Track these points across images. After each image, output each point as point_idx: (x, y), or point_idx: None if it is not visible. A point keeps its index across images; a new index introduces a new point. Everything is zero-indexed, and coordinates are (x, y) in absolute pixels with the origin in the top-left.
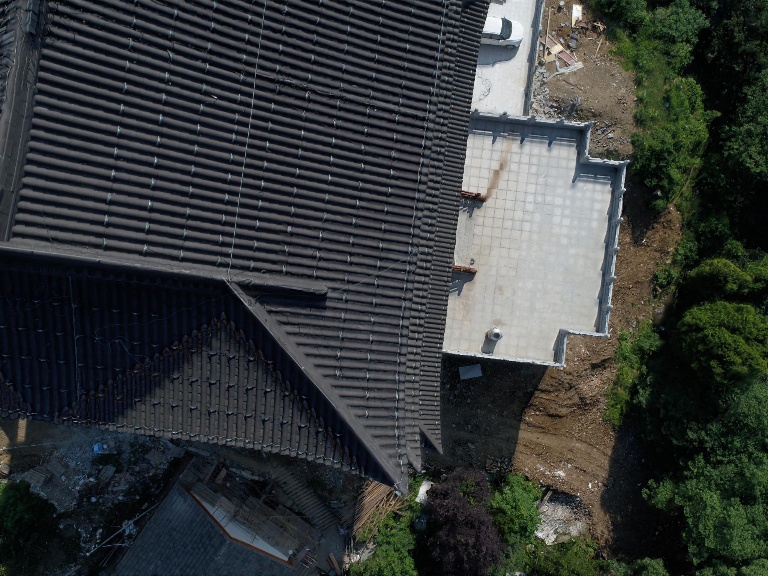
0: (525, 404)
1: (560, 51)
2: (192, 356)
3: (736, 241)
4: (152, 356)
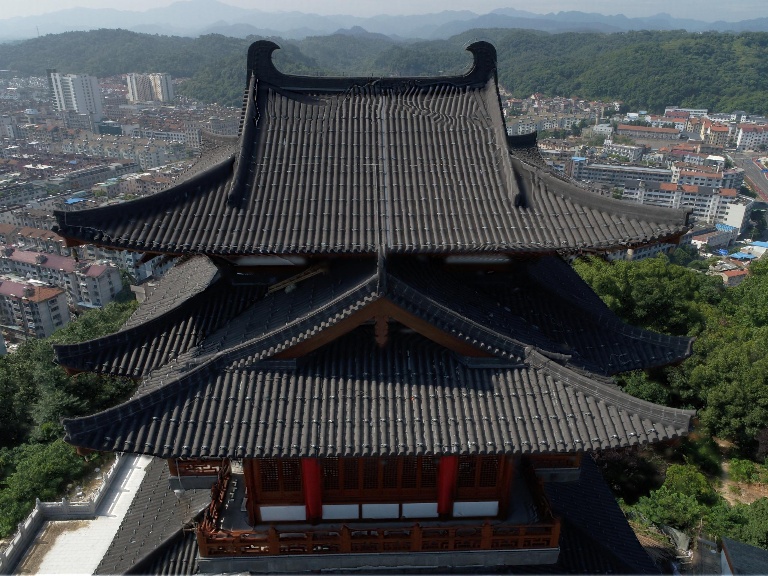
0: None
1: None
2: None
3: None
4: None
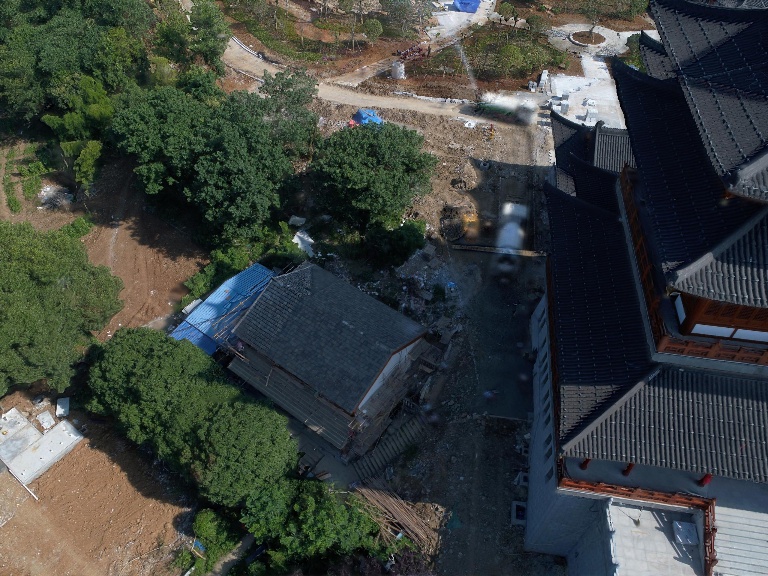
0: None
1: None
2: (764, 105)
3: None
4: (753, 93)
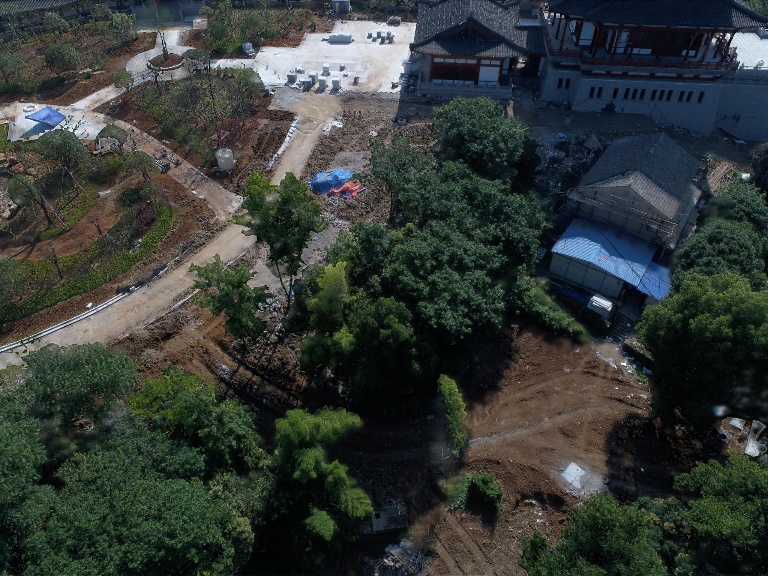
0: None
1: None
2: None
3: None
4: None
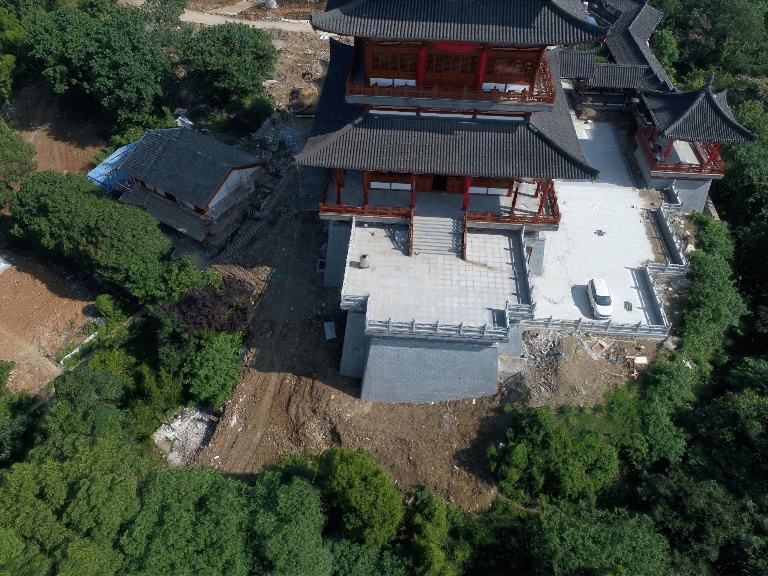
0: (301, 374)
1: (602, 344)
2: None
3: (469, 553)
4: None
